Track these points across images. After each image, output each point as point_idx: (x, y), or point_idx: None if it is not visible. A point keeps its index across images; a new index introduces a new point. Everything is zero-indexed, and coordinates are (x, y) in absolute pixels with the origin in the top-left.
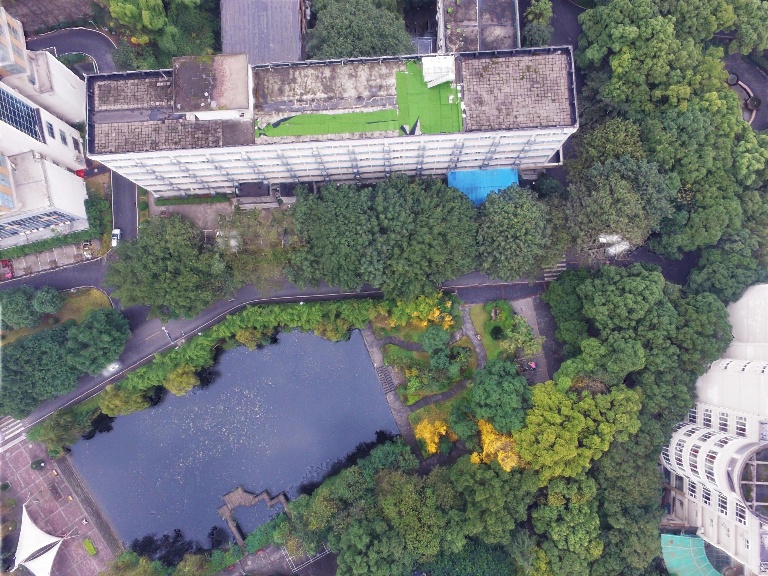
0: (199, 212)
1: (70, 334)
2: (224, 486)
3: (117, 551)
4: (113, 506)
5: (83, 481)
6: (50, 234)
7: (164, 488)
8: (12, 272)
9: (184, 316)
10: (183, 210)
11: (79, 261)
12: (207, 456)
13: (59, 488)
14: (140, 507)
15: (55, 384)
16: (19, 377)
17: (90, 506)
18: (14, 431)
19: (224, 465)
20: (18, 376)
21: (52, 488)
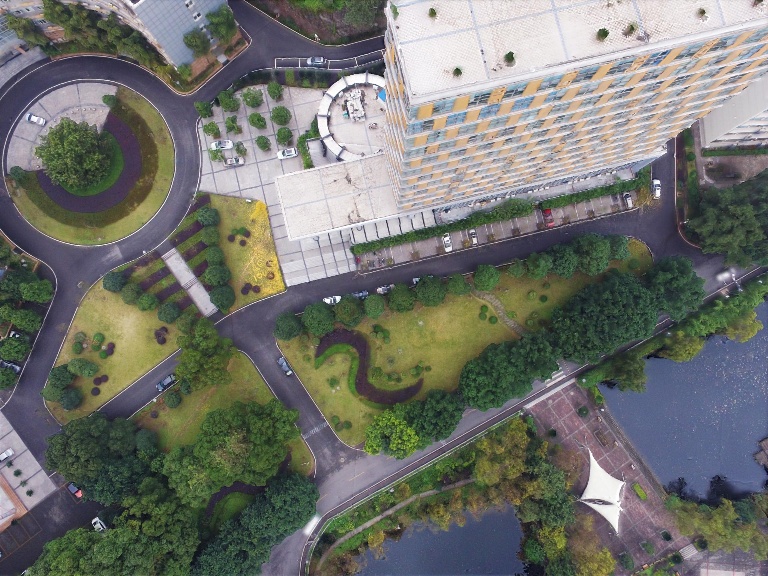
0: (744, 163)
1: (660, 279)
2: (759, 432)
3: (662, 495)
4: (652, 452)
5: (621, 428)
6: (595, 184)
7: (700, 435)
8: (553, 221)
9: (760, 263)
10: (729, 161)
11: (616, 211)
12: (741, 403)
13: (603, 434)
14: (677, 453)
15: (648, 328)
16: (616, 321)
17: (632, 452)
18: (556, 379)
19: (758, 412)
20: (616, 320)
21: (600, 434)
